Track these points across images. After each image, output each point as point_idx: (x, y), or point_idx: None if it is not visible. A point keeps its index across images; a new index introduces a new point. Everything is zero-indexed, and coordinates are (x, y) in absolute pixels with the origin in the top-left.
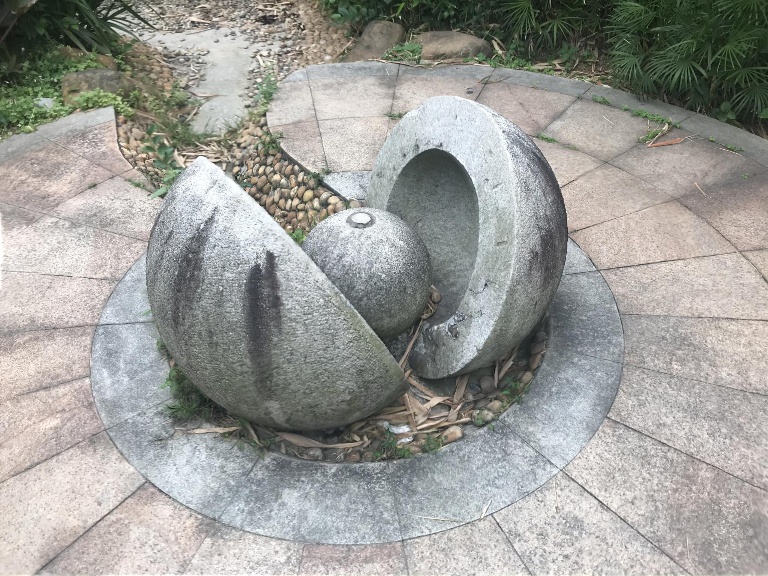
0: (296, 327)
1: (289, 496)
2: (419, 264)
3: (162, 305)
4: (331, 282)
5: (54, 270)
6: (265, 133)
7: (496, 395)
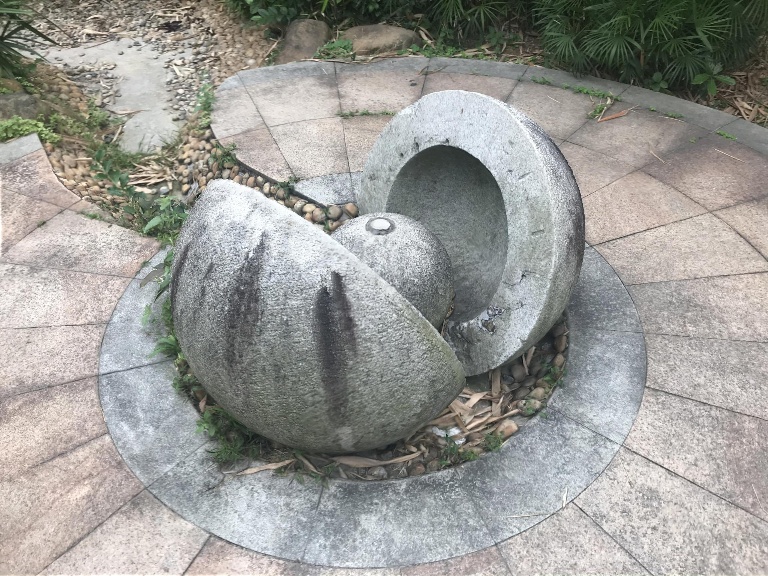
0: (371, 347)
1: (368, 522)
2: (444, 263)
3: (209, 345)
4: (401, 295)
5: (28, 322)
6: (214, 146)
7: (533, 382)
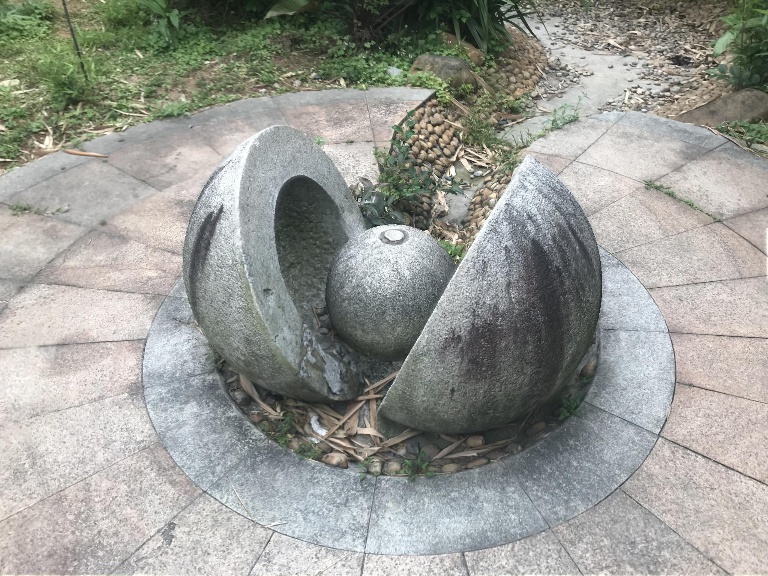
0: (211, 273)
1: (191, 407)
2: (413, 300)
3: None
4: (242, 251)
5: None
6: None
7: None
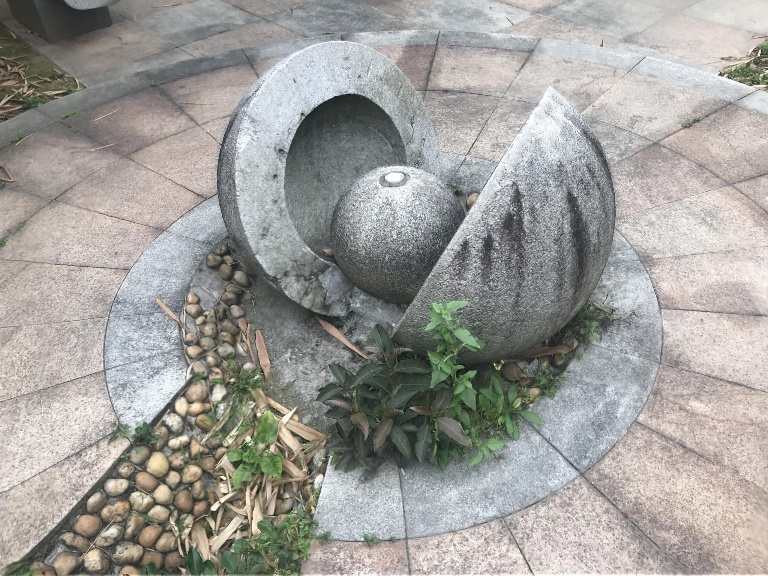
0: None
1: None
2: None
3: None
4: None
5: None
6: None
7: None
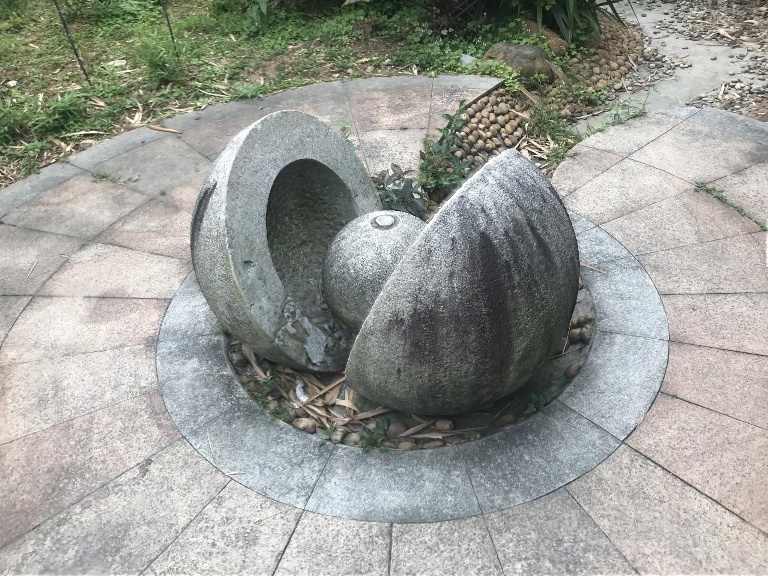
0: (202, 242)
1: (192, 363)
2: None
3: None
4: (225, 224)
5: None
6: None
7: None
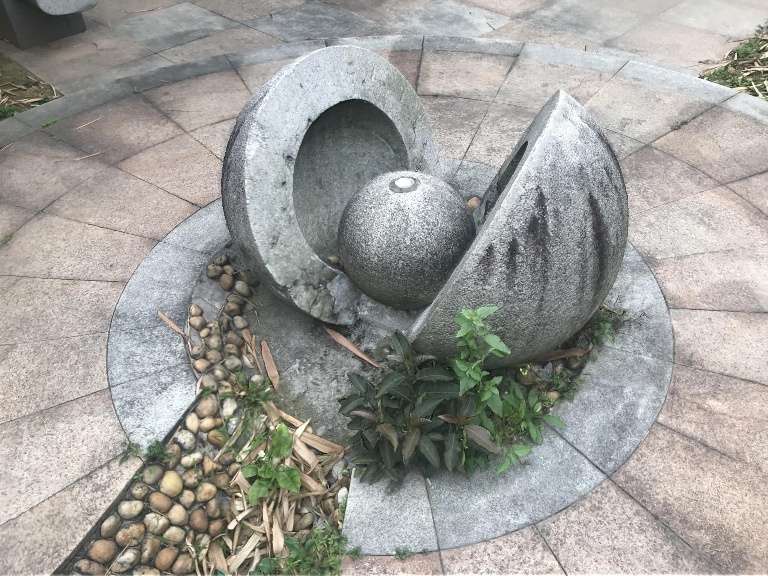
0: None
1: None
2: None
3: None
4: None
5: None
6: None
7: None
